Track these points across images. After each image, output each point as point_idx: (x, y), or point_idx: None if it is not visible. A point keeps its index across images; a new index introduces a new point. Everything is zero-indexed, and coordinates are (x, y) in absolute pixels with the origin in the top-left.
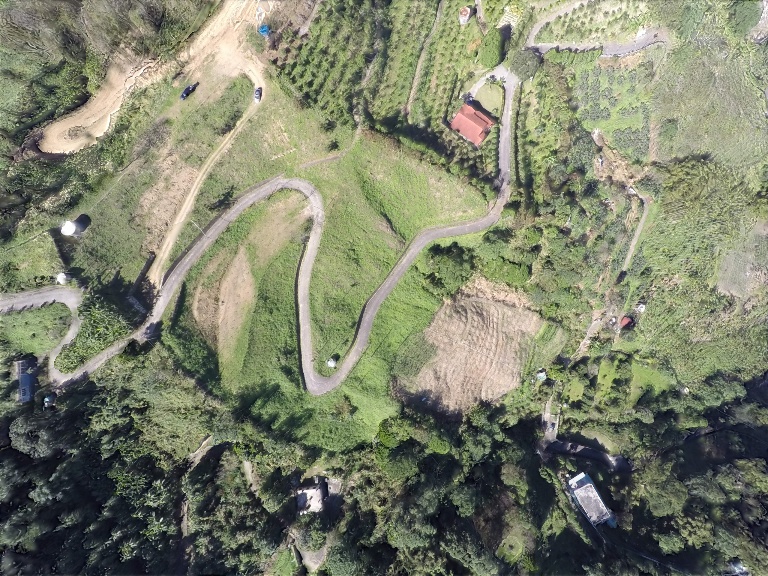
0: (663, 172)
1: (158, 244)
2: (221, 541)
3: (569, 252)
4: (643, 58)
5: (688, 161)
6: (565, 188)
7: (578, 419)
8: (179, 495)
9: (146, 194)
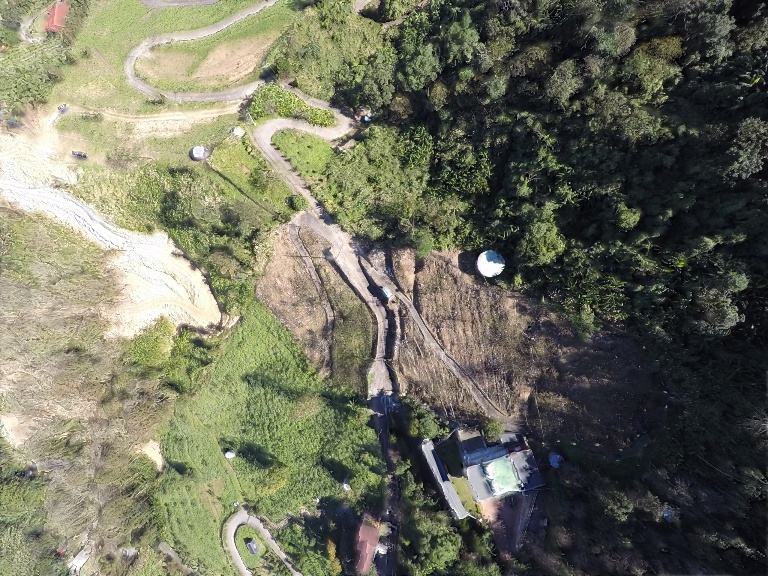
0: None
1: None
2: None
3: None
4: None
5: None
6: None
7: None
8: None
9: None
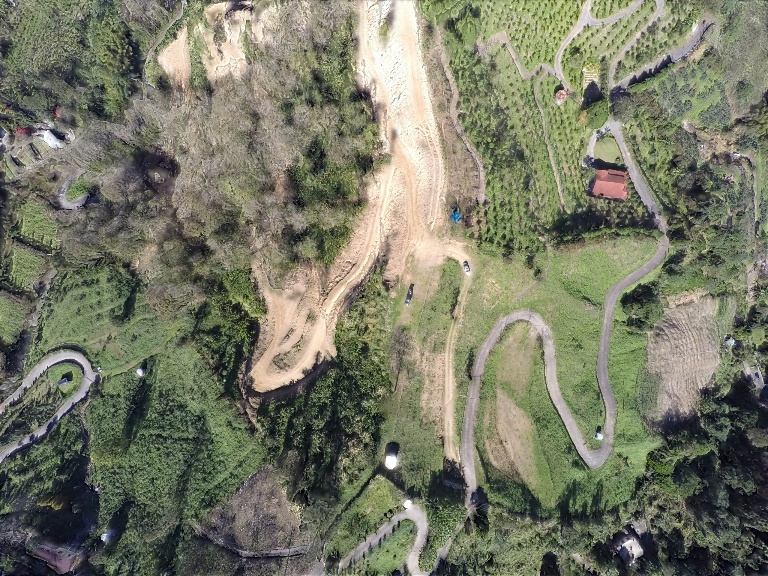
0: (753, 126)
1: (441, 428)
2: None
3: (731, 241)
4: (706, 47)
5: (767, 105)
6: (697, 189)
7: None
8: None
9: (422, 397)
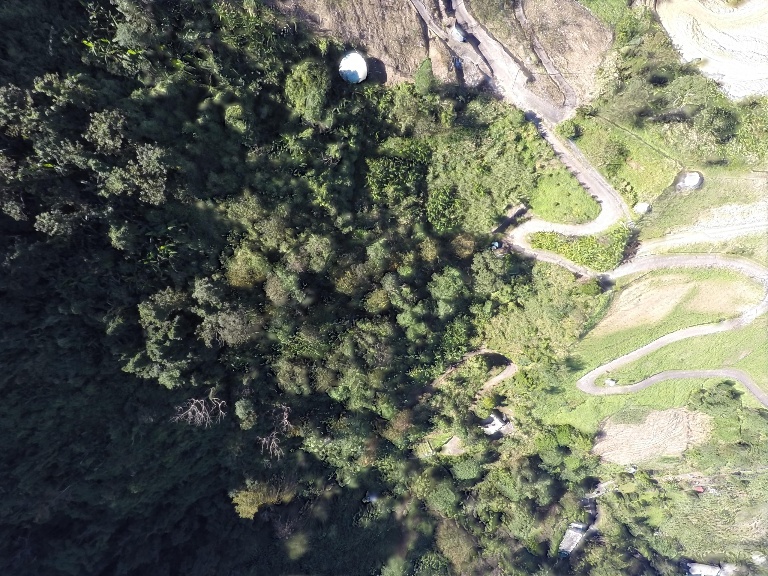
0: None
1: (678, 231)
2: (443, 406)
3: None
4: None
5: None
6: None
7: (607, 500)
8: (455, 361)
9: (736, 203)
